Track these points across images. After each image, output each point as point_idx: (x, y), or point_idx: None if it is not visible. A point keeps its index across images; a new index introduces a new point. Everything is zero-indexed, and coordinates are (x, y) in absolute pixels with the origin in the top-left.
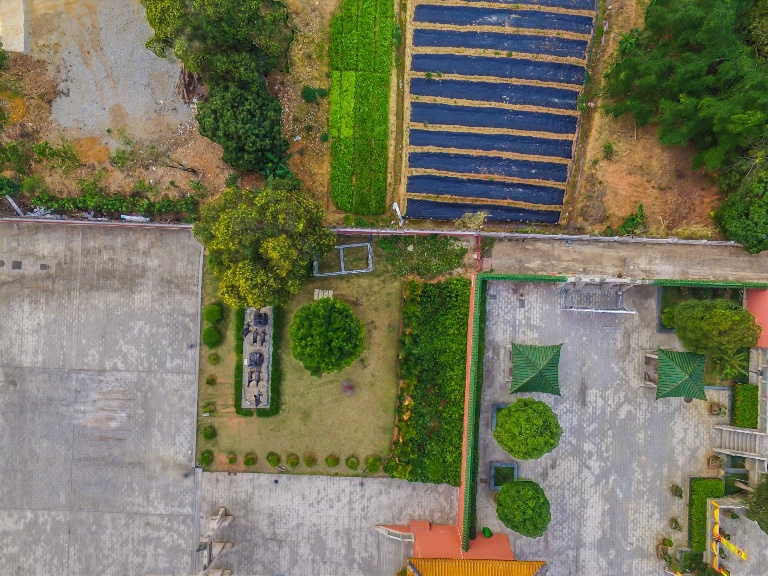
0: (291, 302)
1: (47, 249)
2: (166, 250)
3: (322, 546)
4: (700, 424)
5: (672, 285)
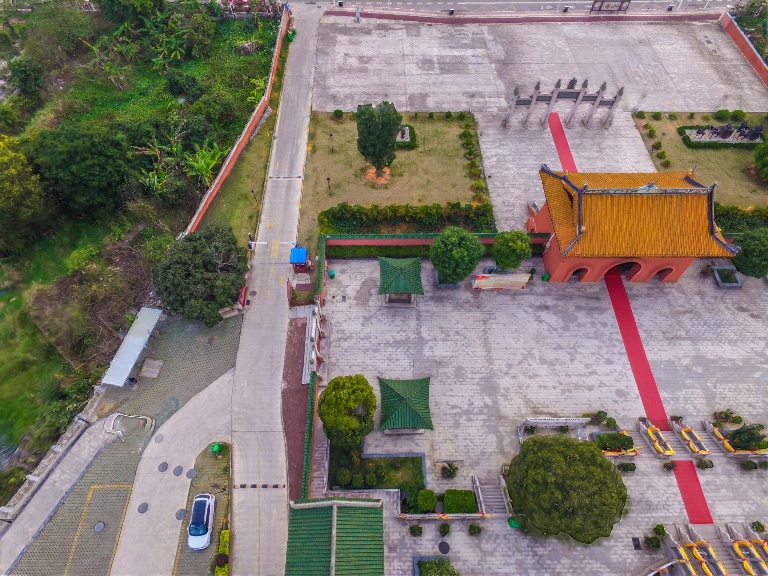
0: None
1: (726, 52)
2: (760, 97)
3: None
4: None
5: None
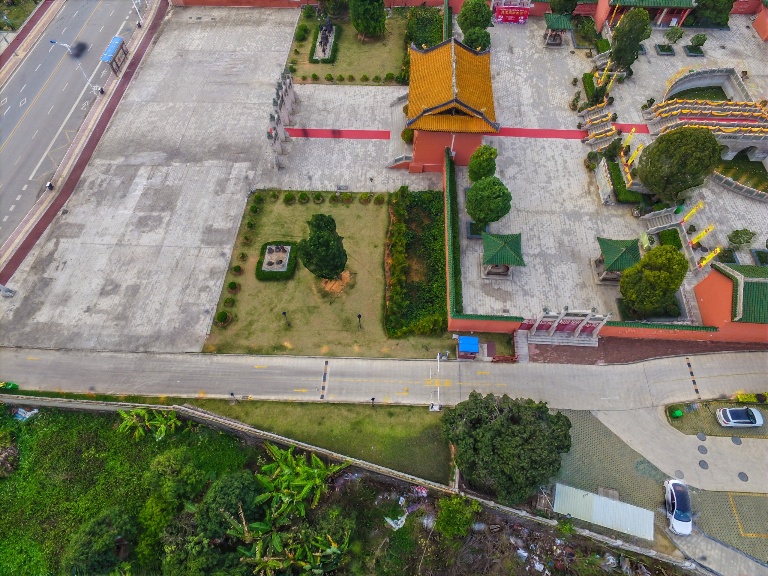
0: (345, 28)
1: (217, 14)
2: (280, 14)
3: (355, 113)
4: (582, 61)
5: (548, 1)
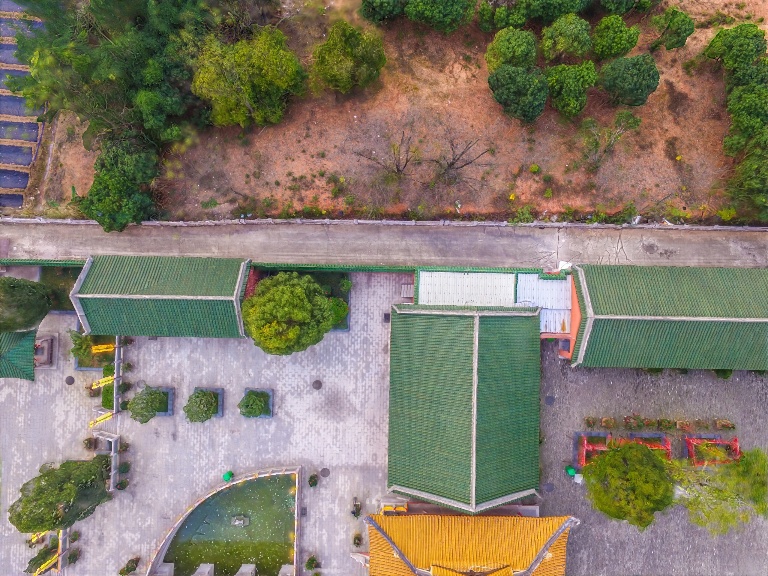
0: None
1: None
2: None
3: None
4: (81, 406)
5: (14, 264)
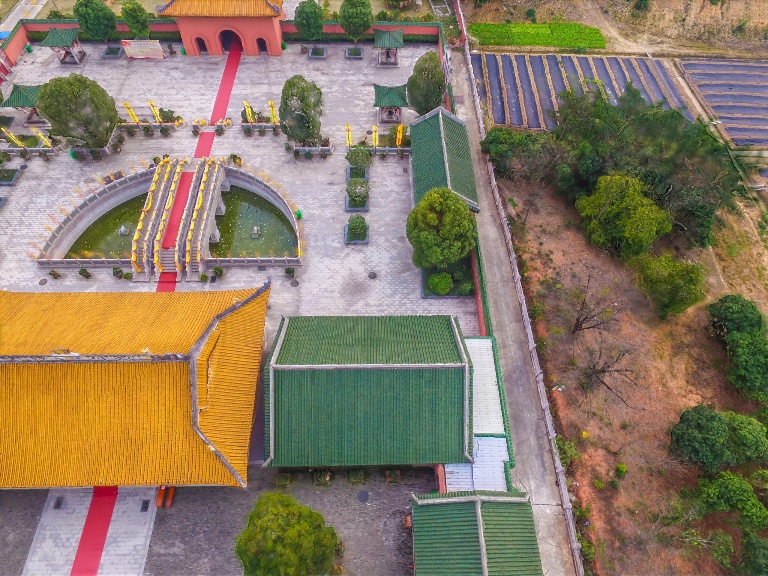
0: None
1: None
2: None
3: None
4: None
5: None
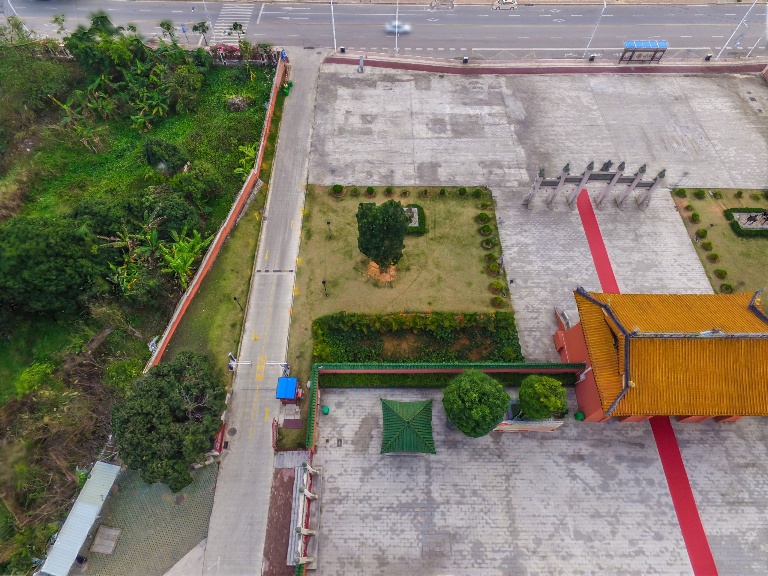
0: None
1: None
2: None
3: (645, 269)
4: None
5: None
